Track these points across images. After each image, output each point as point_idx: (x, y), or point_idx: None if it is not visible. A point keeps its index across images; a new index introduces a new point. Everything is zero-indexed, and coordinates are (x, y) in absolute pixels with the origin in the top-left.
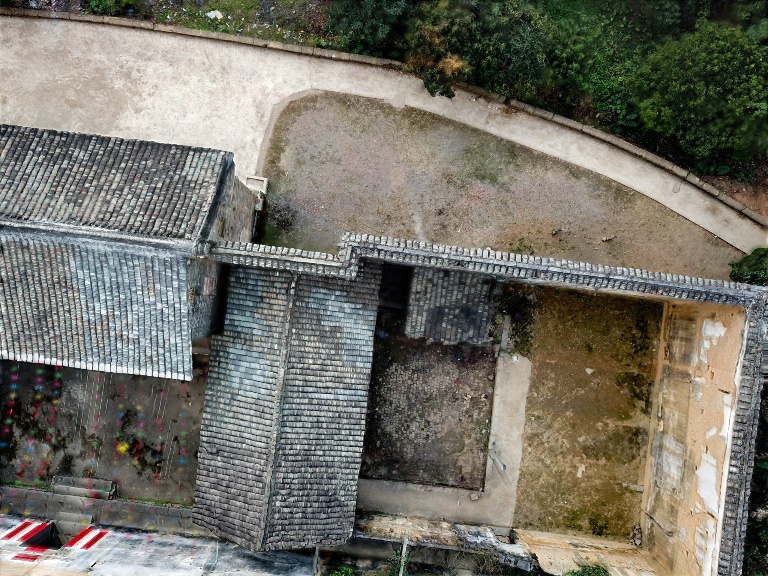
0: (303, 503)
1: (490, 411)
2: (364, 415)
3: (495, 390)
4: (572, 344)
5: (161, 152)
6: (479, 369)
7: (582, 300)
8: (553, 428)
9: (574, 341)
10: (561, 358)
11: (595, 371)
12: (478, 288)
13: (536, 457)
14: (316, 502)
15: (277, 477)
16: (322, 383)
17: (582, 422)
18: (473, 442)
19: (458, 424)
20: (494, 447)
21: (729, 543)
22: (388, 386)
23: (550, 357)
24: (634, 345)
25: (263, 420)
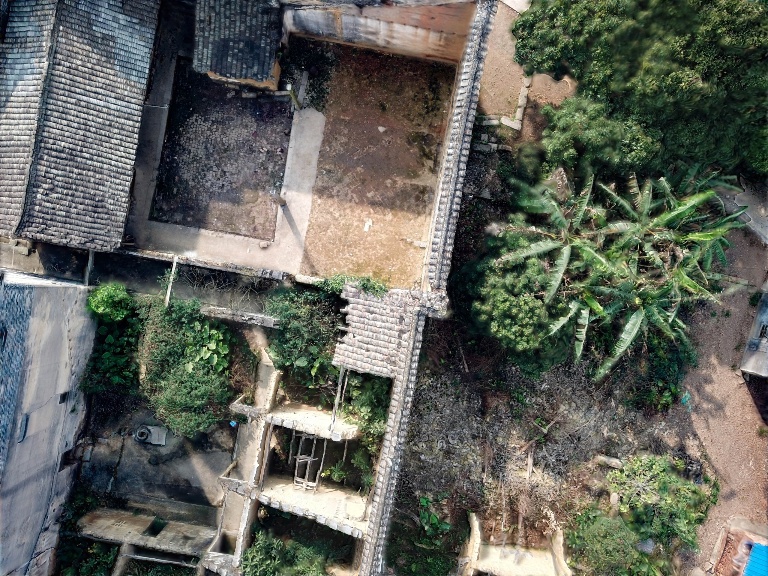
0: (67, 202)
1: (285, 165)
2: (137, 129)
3: (289, 143)
4: (367, 102)
5: None
6: (277, 124)
7: (378, 60)
8: (343, 182)
9: (369, 100)
10: (355, 115)
11: (387, 130)
12: (259, 19)
13: (325, 209)
14: (82, 204)
15: (39, 170)
16: (92, 87)
17: (372, 178)
18: (267, 194)
19: (253, 176)
20: (285, 197)
21: (441, 220)
22: (187, 135)
23: (344, 113)
24: (426, 106)
25: (29, 115)
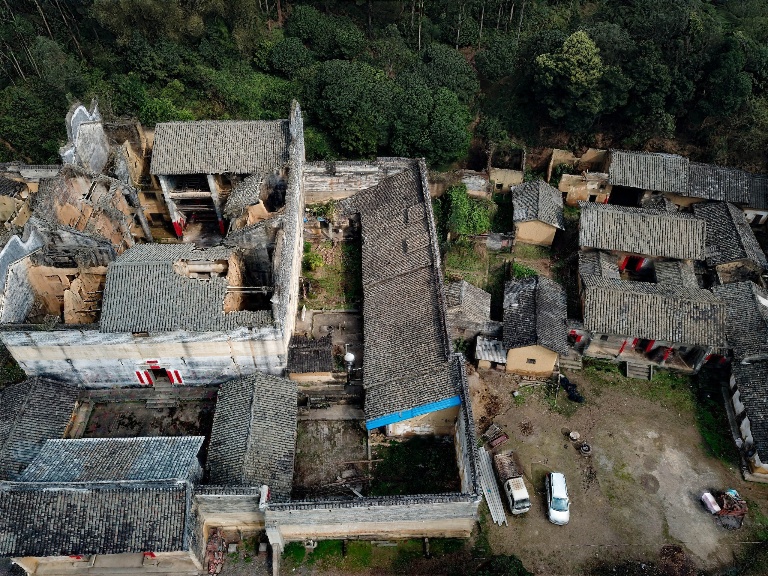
0: None
1: None
2: None
3: None
4: None
5: (30, 550)
6: None
7: None
8: None
9: None
10: None
11: None
12: None
13: None
14: None
15: None
16: None
17: None
18: None
19: None
20: None
21: None
22: None
23: None
24: None
25: (21, 430)
